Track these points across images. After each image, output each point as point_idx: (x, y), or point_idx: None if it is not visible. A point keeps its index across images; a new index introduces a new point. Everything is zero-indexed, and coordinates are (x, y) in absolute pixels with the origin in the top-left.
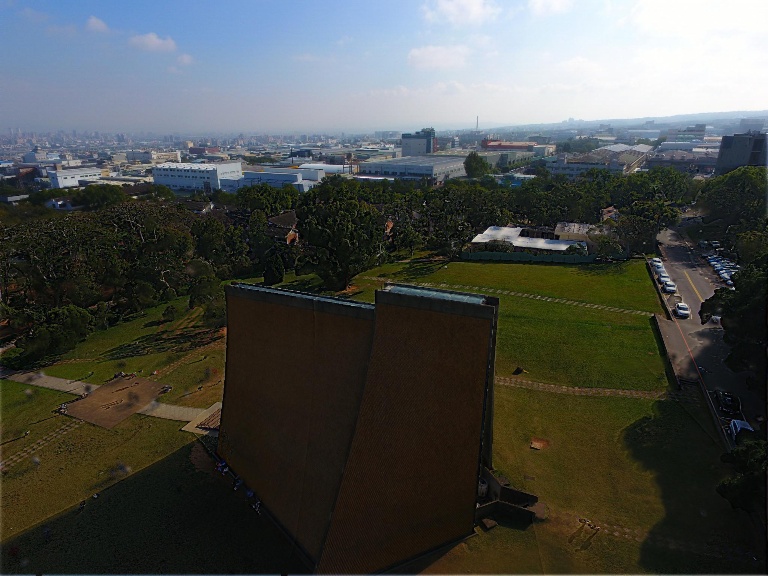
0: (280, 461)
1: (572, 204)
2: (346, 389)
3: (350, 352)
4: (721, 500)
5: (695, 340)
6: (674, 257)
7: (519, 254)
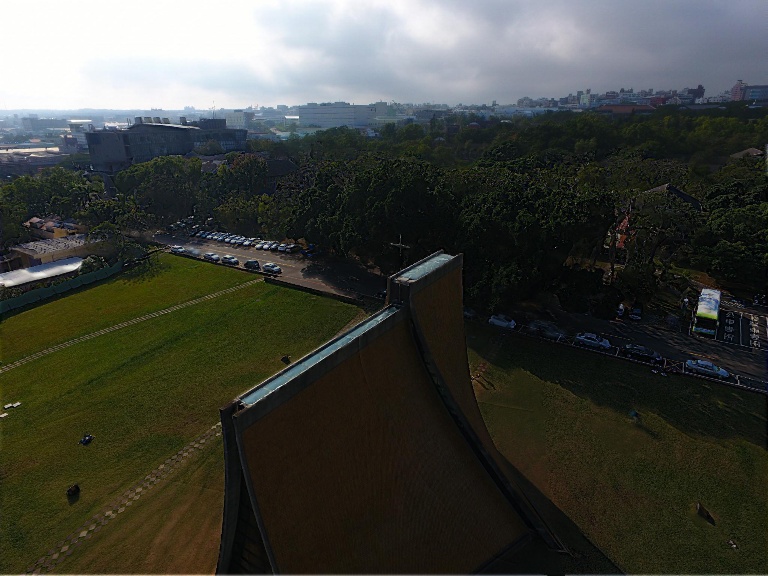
0: (422, 539)
1: (1, 222)
2: (417, 403)
3: (399, 367)
4: (466, 328)
5: (313, 279)
6: (173, 243)
7: (34, 292)
